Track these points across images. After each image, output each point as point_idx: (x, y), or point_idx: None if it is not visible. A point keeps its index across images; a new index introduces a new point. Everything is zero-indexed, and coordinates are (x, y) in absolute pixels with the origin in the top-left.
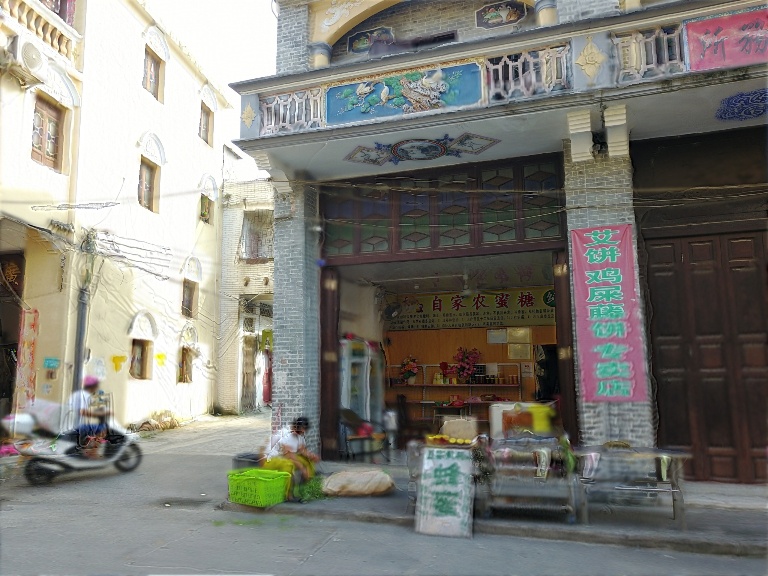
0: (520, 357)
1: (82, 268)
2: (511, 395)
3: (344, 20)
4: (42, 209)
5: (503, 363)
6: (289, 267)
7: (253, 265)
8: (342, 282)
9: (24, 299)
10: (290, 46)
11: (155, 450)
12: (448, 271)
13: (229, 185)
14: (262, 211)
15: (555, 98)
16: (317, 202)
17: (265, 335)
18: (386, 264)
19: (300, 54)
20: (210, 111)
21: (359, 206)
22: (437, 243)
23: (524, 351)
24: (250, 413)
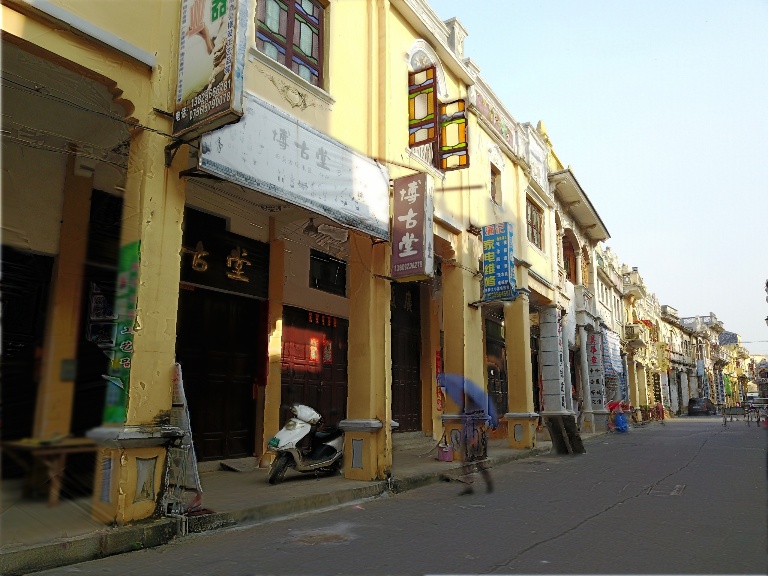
0: None
1: None
2: None
3: (759, 371)
4: None
5: None
6: None
7: None
8: (763, 391)
9: None
10: None
11: None
12: None
13: None
14: None
15: (766, 382)
16: (760, 385)
17: None
18: (765, 390)
19: None
20: (765, 359)
21: None
22: (767, 389)
23: None
24: None
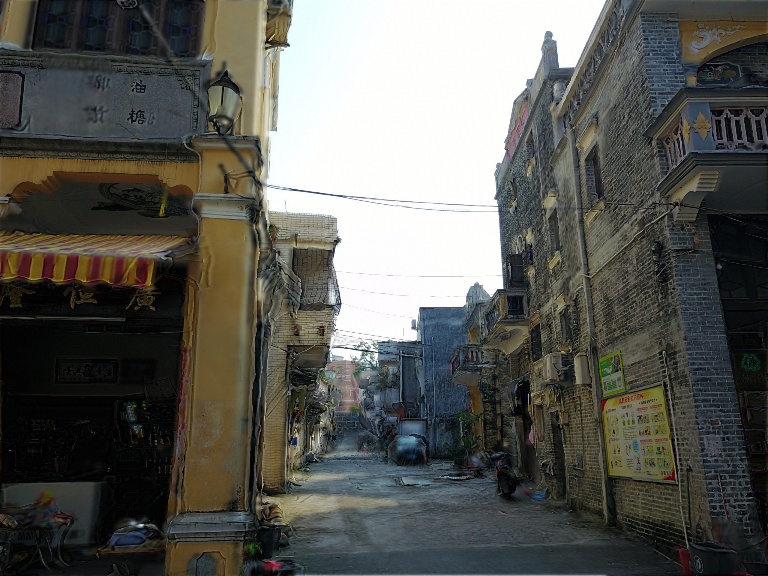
0: (765, 422)
1: (267, 294)
2: (764, 463)
3: (714, 47)
4: (368, 204)
5: (759, 429)
6: (703, 308)
7: (305, 311)
8: None
9: (190, 330)
10: (662, 61)
11: (382, 544)
12: (744, 327)
13: (277, 216)
14: (316, 250)
15: None
16: None
17: (295, 395)
18: None
19: (677, 72)
20: None
21: (749, 246)
22: None
23: (767, 416)
24: (291, 491)
